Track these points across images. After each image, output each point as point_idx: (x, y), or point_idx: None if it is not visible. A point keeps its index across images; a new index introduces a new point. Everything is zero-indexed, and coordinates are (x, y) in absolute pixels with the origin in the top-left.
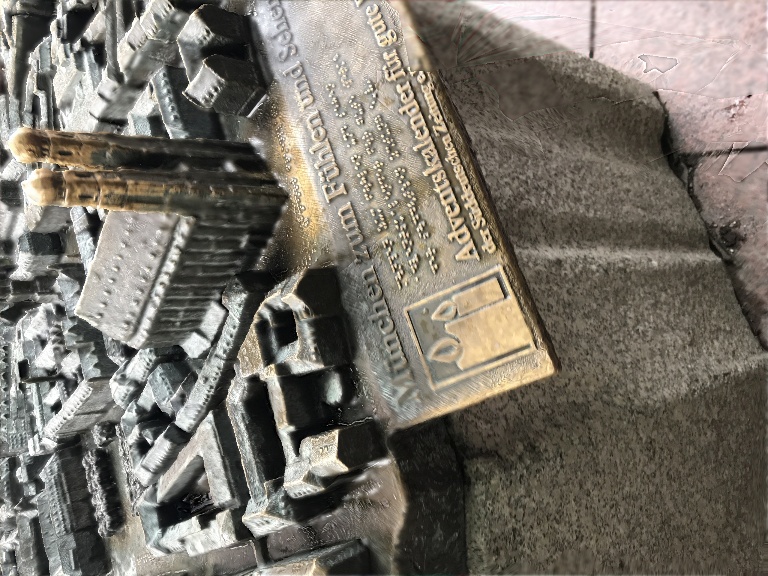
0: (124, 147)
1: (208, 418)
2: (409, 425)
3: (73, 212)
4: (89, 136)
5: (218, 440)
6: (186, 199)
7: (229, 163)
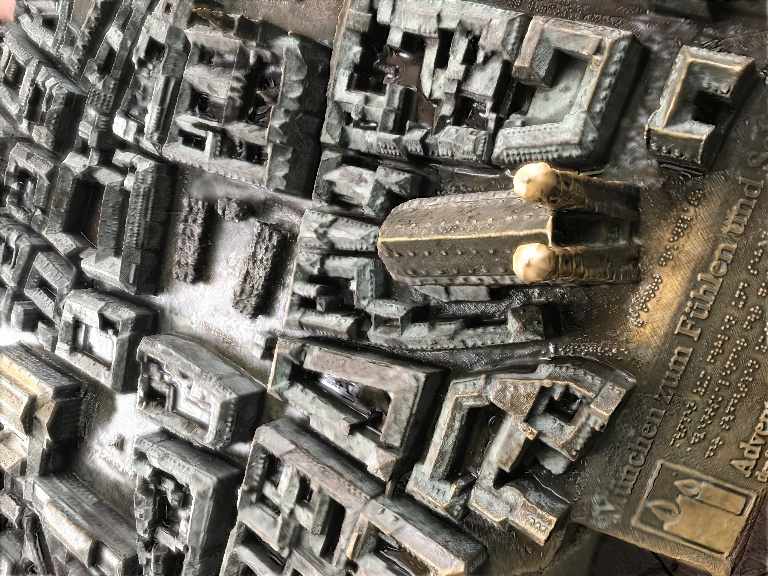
0: (590, 205)
1: (417, 375)
2: None
3: None
4: (578, 185)
5: (417, 400)
6: (593, 280)
7: (627, 228)
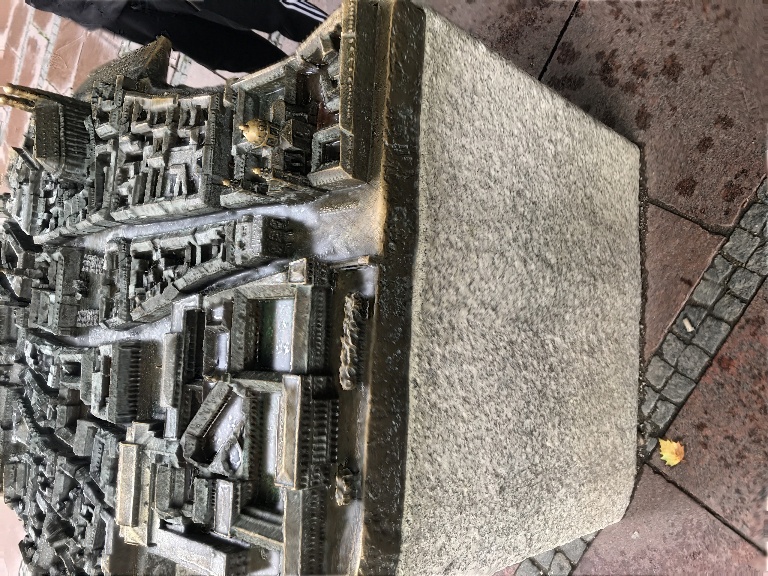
0: None
1: None
2: (141, 73)
3: (34, 235)
4: None
5: None
6: (57, 98)
7: None
